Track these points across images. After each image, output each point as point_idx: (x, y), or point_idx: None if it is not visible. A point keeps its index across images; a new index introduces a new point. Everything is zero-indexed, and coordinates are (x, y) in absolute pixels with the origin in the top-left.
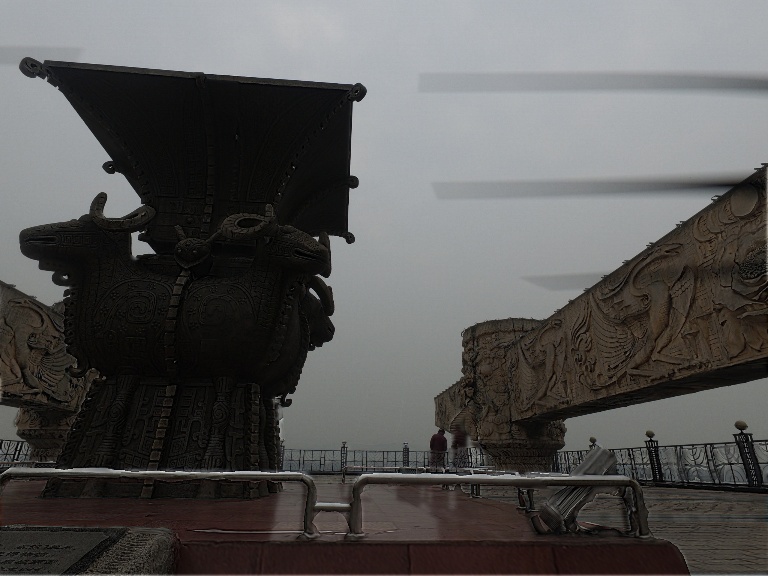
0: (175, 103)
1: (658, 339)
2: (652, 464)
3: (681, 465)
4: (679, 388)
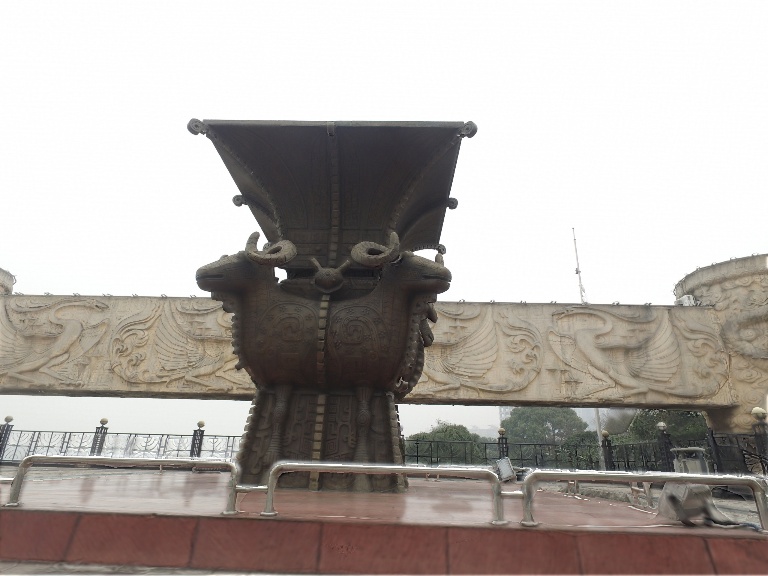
0: (434, 192)
1: (229, 362)
2: (93, 448)
3: (129, 450)
4: (209, 396)
